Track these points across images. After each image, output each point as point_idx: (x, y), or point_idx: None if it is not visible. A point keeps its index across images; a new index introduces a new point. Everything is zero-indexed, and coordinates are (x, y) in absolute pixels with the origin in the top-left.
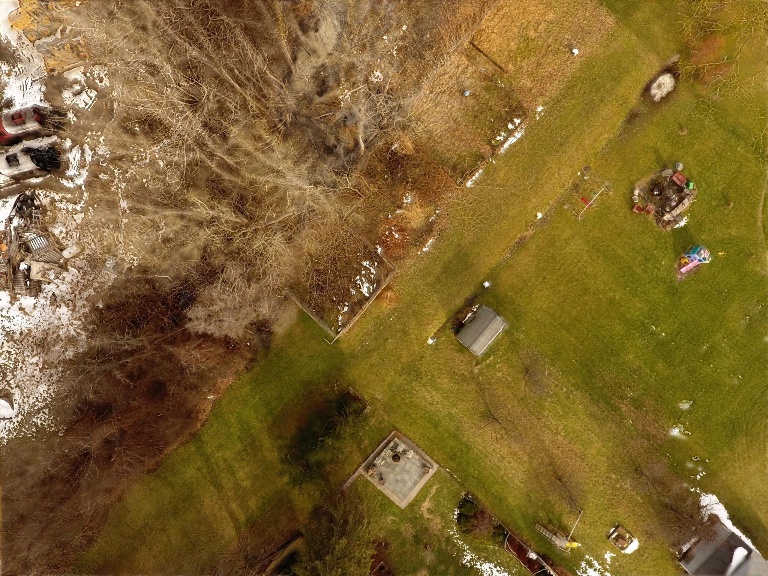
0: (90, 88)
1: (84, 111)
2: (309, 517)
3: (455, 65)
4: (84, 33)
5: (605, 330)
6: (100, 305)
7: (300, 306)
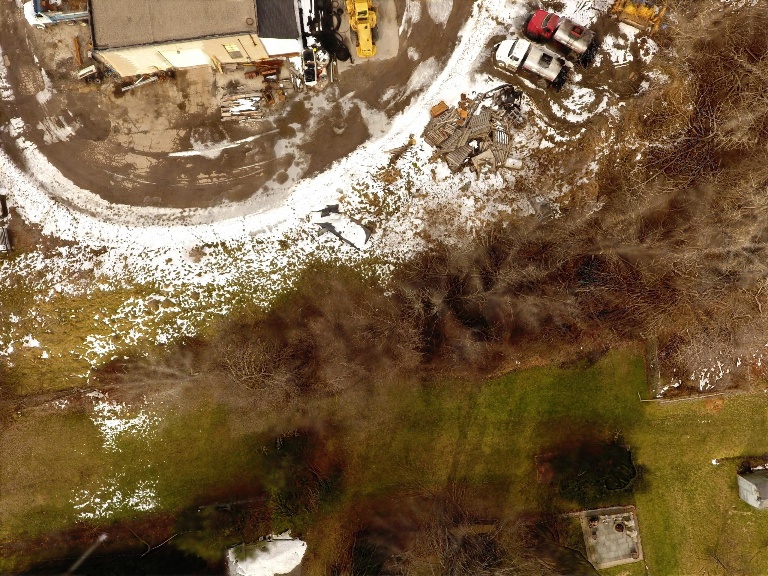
0: (631, 52)
1: (610, 65)
2: (516, 515)
3: None
4: (662, 6)
5: None
6: (505, 225)
7: None
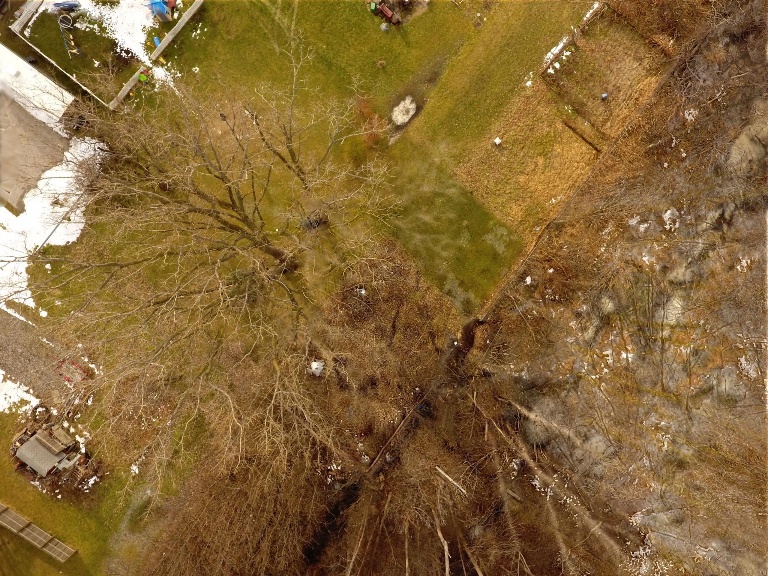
0: None
1: None
2: None
3: (614, 129)
4: None
5: None
6: None
7: None
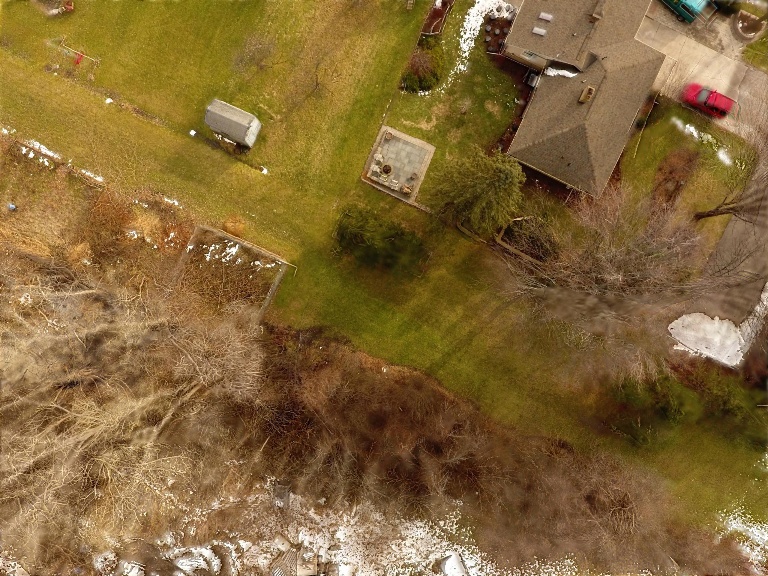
0: (123, 570)
1: (147, 570)
2: None
3: None
4: None
5: (199, 1)
6: (323, 501)
7: (262, 307)
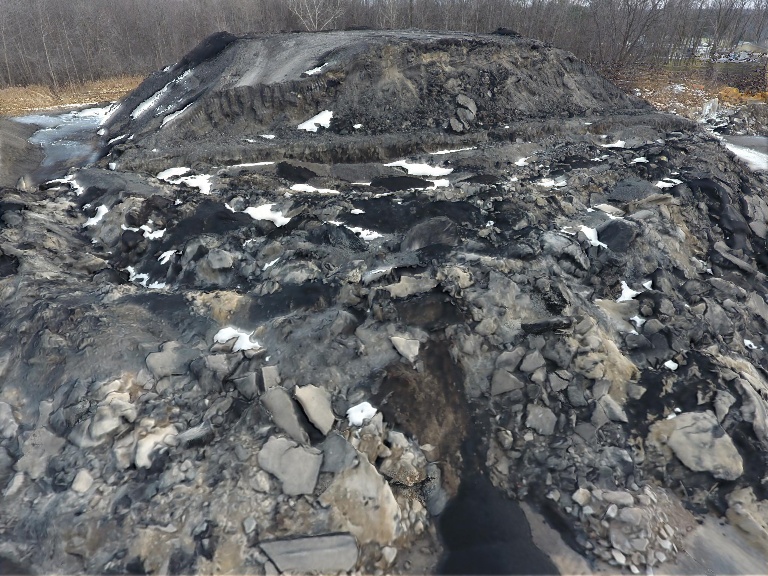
0: None
1: None
2: None
3: None
4: None
5: None
6: None
7: None
